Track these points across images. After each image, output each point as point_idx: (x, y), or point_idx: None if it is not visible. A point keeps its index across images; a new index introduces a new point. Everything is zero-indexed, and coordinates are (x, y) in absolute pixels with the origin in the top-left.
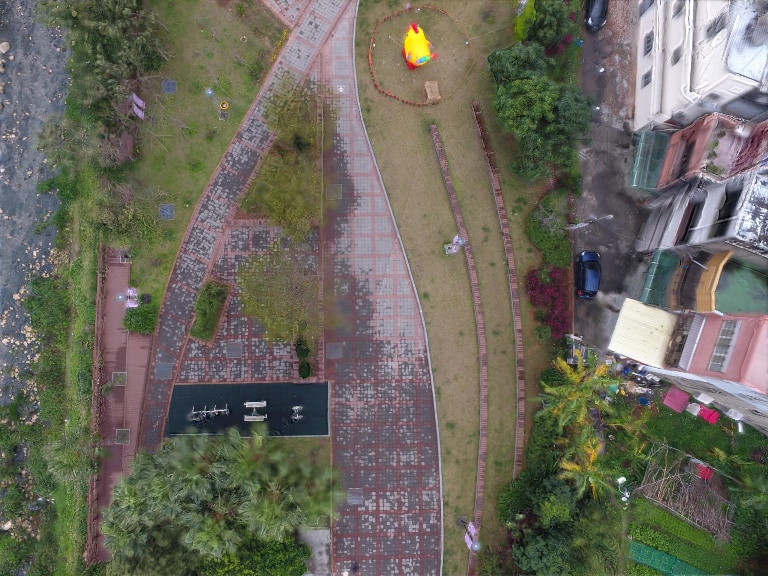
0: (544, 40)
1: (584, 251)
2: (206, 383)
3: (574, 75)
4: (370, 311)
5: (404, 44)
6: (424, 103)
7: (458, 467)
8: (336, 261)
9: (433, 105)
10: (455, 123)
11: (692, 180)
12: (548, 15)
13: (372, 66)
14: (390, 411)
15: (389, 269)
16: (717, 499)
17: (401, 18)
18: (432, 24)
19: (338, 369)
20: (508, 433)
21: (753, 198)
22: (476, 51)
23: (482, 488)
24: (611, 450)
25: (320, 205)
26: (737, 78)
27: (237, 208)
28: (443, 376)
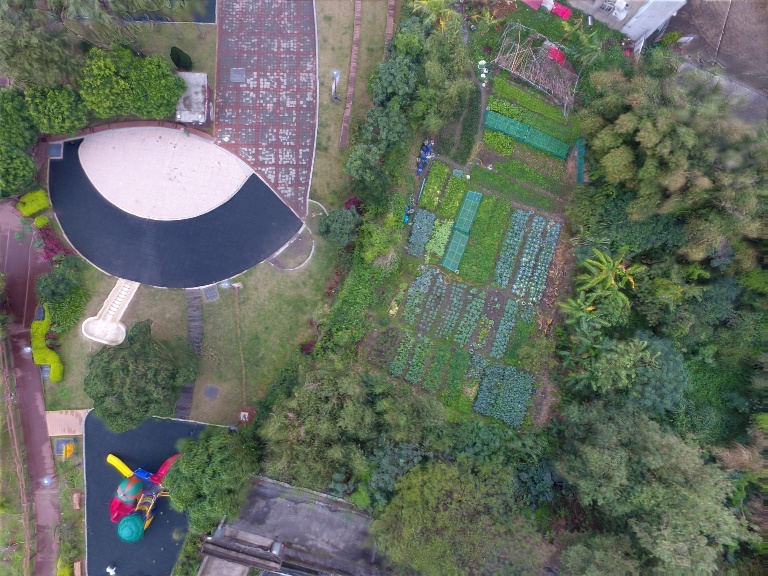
0: None
1: None
2: None
3: None
4: None
5: None
6: None
7: (333, 53)
8: None
9: None
10: None
11: None
12: None
13: None
14: (273, 6)
15: None
16: (566, 74)
17: None
18: None
19: None
20: (380, 24)
21: None
22: None
23: (354, 68)
24: (473, 39)
25: None
26: None
27: None
28: None
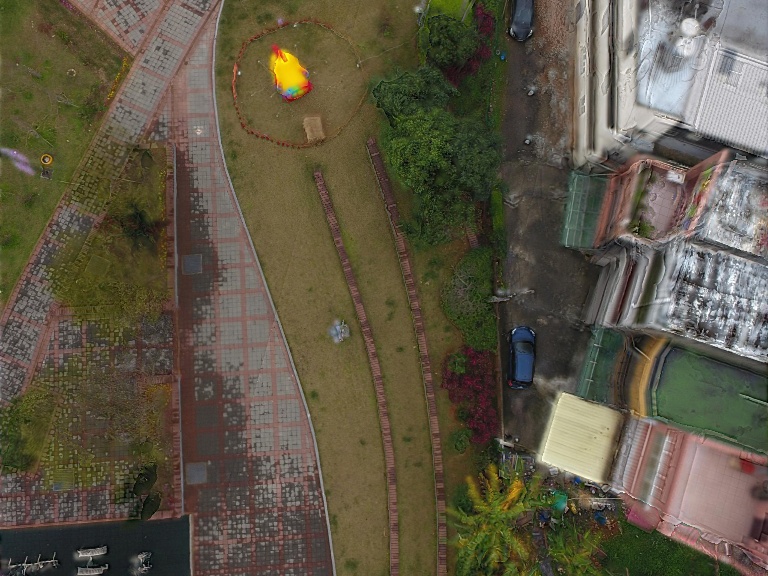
0: (444, 66)
1: (515, 328)
2: (27, 526)
3: (495, 101)
4: (242, 418)
5: (275, 72)
6: (305, 145)
7: None
8: (196, 355)
9: (316, 147)
10: (345, 169)
11: (627, 245)
12: (443, 38)
13: (237, 100)
14: (272, 550)
15: (266, 362)
16: None
17: (273, 37)
18: (313, 43)
19: (202, 497)
20: (427, 572)
21: (689, 275)
22: (370, 75)
23: None
24: None
25: (173, 283)
26: (665, 121)
27: (64, 292)
28: (340, 500)
